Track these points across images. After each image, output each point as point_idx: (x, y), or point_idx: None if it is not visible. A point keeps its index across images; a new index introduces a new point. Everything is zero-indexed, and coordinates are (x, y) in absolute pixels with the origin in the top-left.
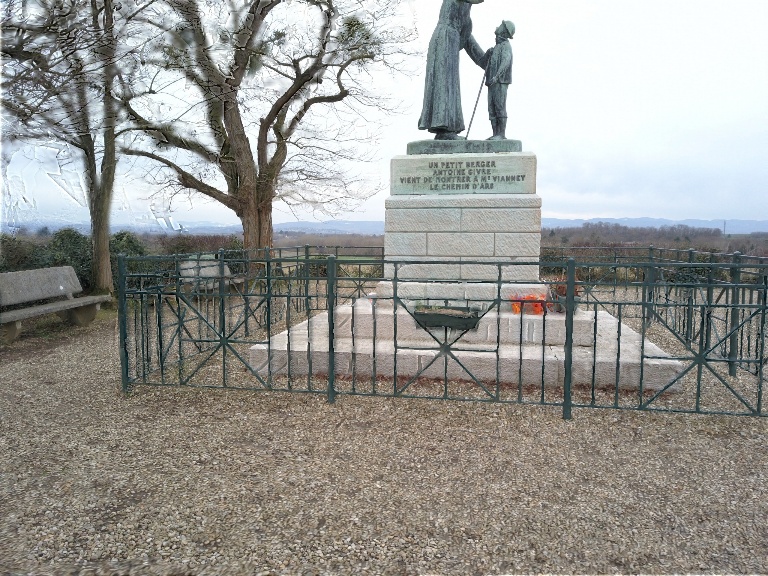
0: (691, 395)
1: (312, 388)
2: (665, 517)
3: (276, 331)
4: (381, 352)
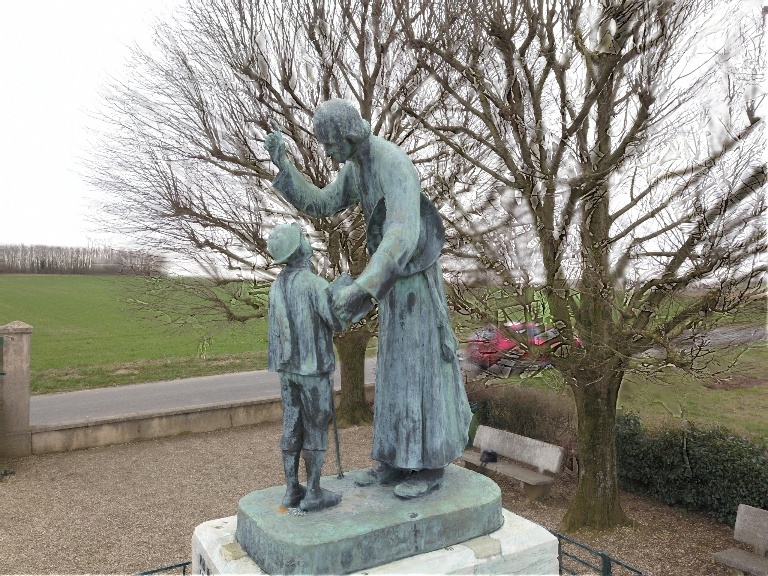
0: None
1: None
2: None
3: None
4: None
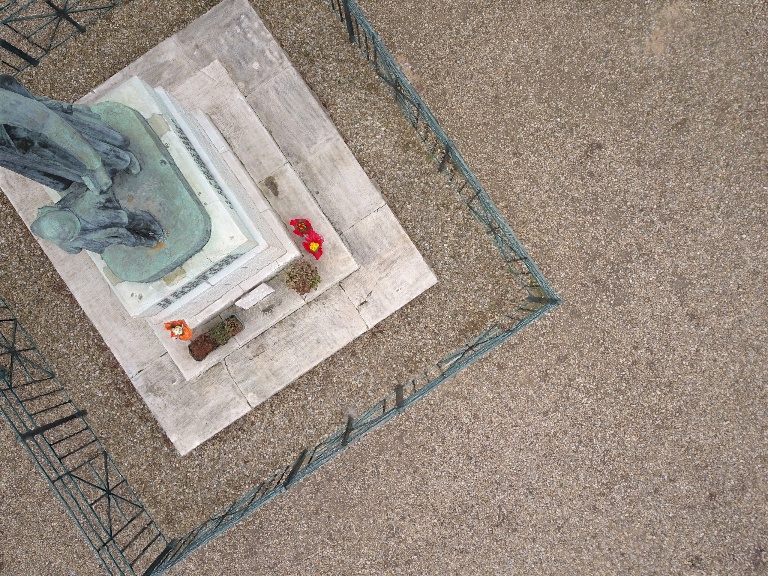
0: (190, 456)
1: (8, 244)
2: (1, 502)
3: (139, 8)
4: (52, 259)
